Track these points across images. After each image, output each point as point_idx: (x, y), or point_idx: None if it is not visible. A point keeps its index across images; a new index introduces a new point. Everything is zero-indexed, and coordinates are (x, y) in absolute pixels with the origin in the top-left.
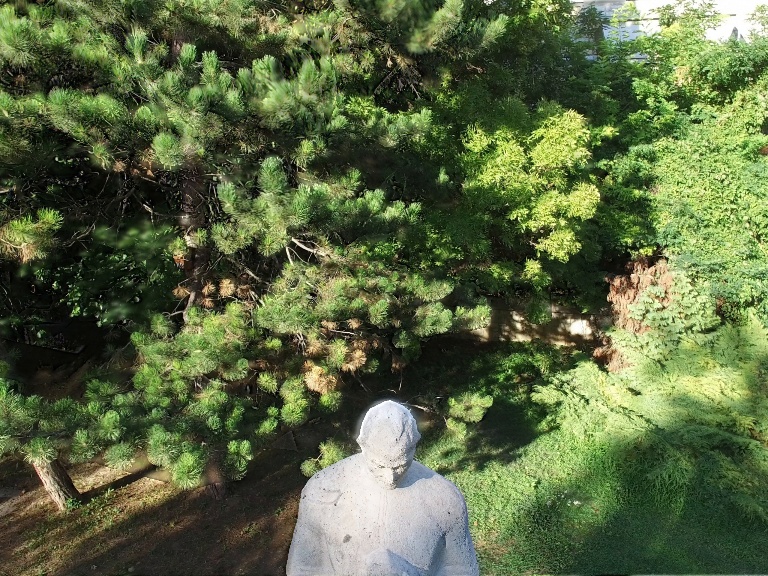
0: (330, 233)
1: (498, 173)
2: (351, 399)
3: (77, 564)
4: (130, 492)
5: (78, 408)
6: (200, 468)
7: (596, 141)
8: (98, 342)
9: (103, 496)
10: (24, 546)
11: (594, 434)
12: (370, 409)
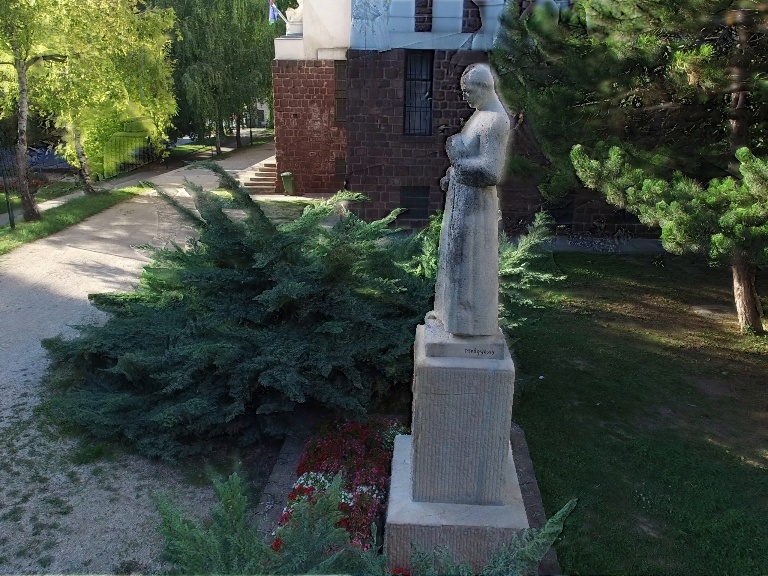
0: None
1: None
2: None
3: (703, 353)
4: None
5: (653, 182)
6: (686, 243)
7: None
8: None
9: None
10: (695, 333)
11: None
12: None
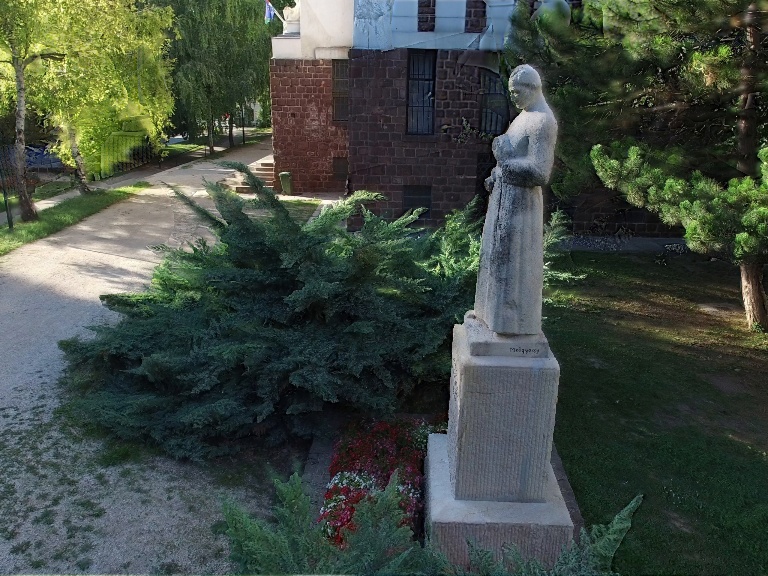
0: None
1: None
2: None
3: (714, 350)
4: None
5: None
6: (710, 242)
7: None
8: None
9: None
10: (704, 330)
11: None
12: None
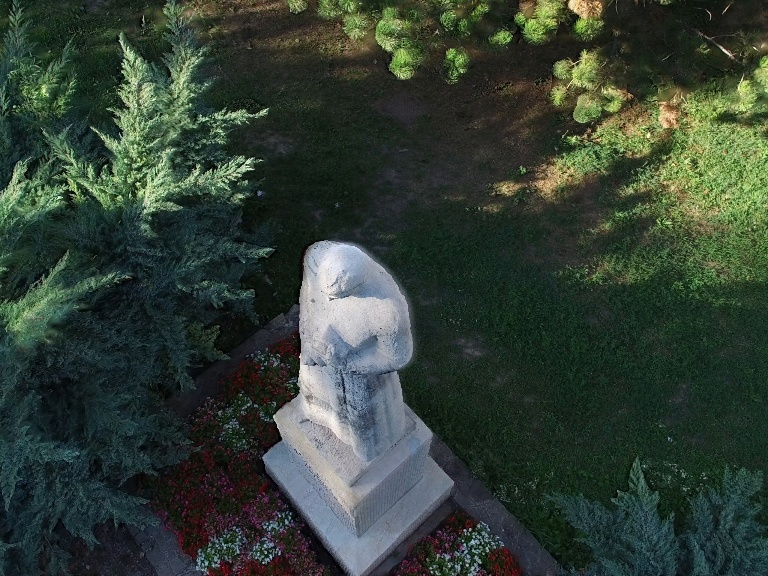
0: None
1: None
2: (651, 7)
3: (366, 52)
4: None
5: None
6: (417, 62)
7: None
8: None
9: None
10: None
11: None
12: (329, 249)
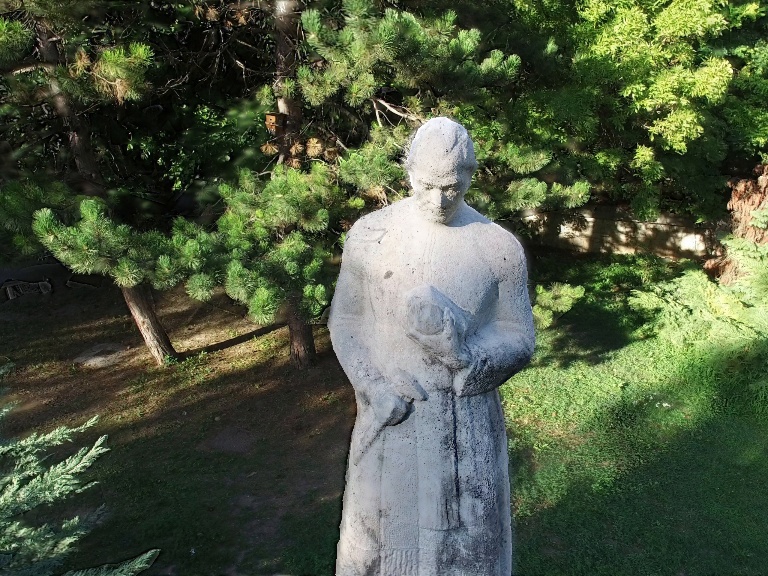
0: (422, 93)
1: (614, 43)
2: None
3: (170, 409)
4: (221, 356)
5: (164, 240)
6: None
7: (736, 23)
8: (191, 198)
9: (197, 357)
10: (126, 390)
11: (694, 342)
12: None
